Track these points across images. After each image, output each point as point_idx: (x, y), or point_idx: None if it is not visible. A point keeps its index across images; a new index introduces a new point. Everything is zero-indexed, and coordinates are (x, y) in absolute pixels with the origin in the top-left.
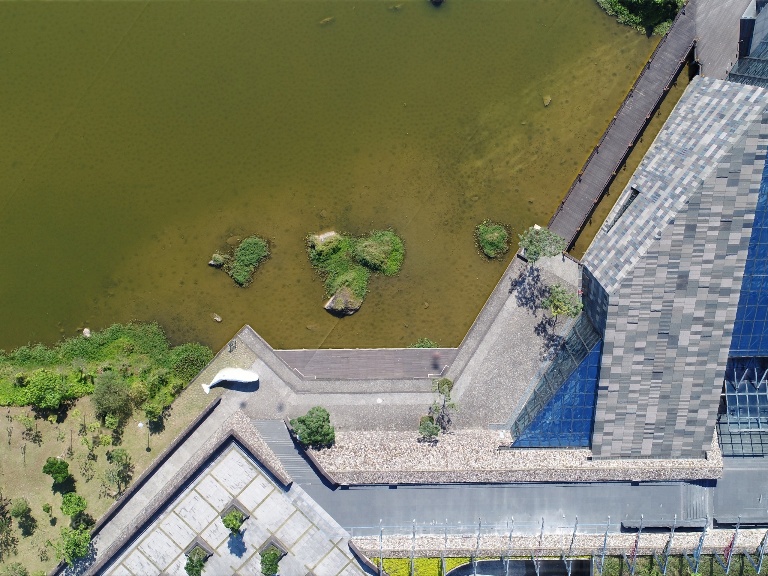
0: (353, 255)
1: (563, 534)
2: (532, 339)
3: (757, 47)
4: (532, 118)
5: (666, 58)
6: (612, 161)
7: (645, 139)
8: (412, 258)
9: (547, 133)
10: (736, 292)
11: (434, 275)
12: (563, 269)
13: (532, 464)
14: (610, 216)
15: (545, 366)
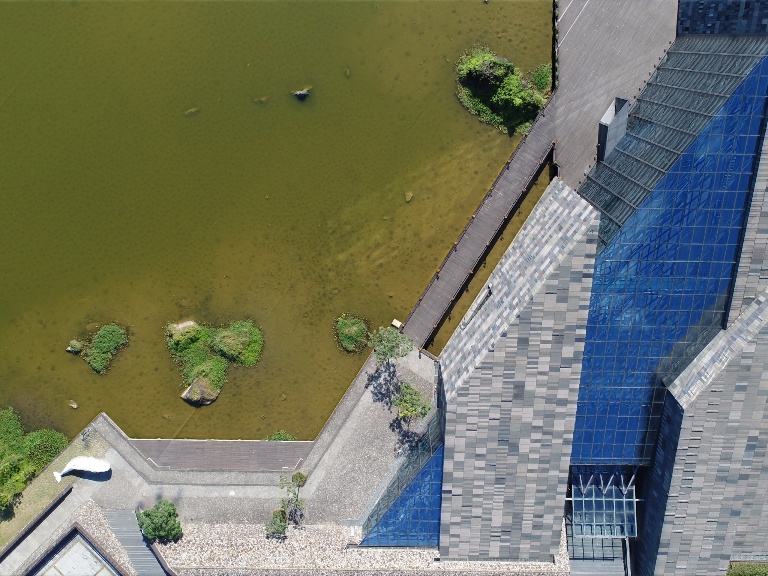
0: (211, 345)
1: None
2: (387, 435)
3: (611, 153)
4: (394, 213)
5: (525, 159)
6: (470, 259)
7: (505, 237)
8: (271, 349)
9: (408, 228)
10: (573, 403)
11: (292, 367)
12: (419, 365)
13: (378, 564)
14: (468, 313)
15: (399, 462)
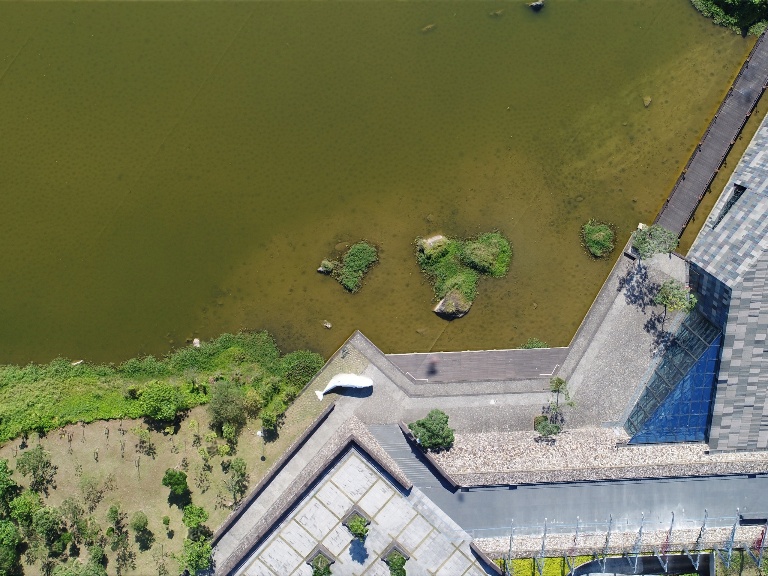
0: (461, 258)
1: (683, 529)
2: (642, 336)
3: None
4: (633, 119)
5: (763, 57)
6: (714, 159)
7: (744, 136)
8: (519, 259)
9: (648, 133)
10: None
11: (542, 276)
12: (670, 266)
13: (651, 460)
14: (714, 213)
15: (656, 362)
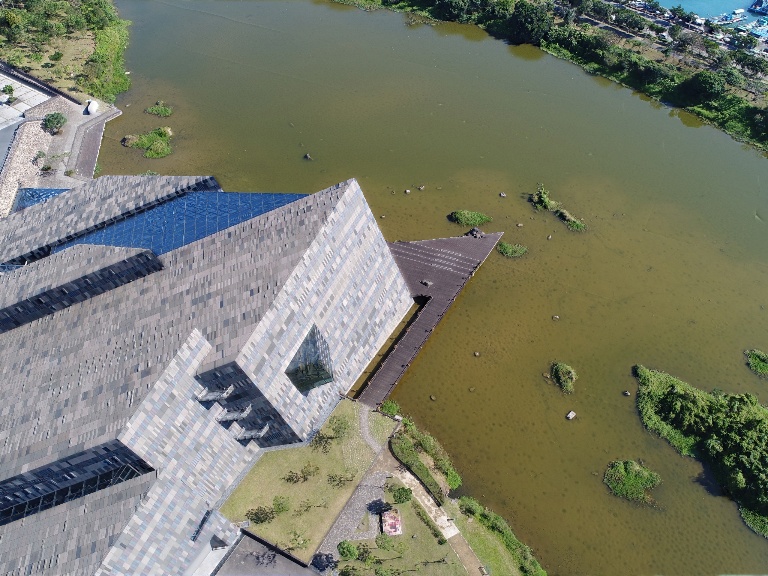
0: None
1: None
2: None
3: None
4: None
5: None
6: None
7: None
8: None
9: None
10: None
11: None
12: None
13: (5, 192)
14: None
15: None
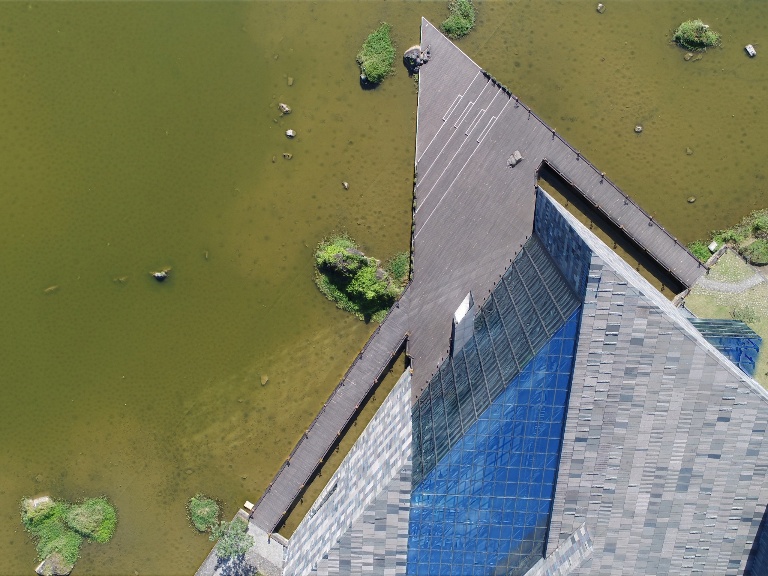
0: (66, 521)
1: None
2: None
3: (459, 352)
4: (249, 396)
5: (378, 349)
6: (321, 447)
7: (359, 423)
8: (124, 527)
9: (263, 411)
10: None
11: (145, 545)
12: (268, 550)
13: None
14: (318, 499)
15: None
